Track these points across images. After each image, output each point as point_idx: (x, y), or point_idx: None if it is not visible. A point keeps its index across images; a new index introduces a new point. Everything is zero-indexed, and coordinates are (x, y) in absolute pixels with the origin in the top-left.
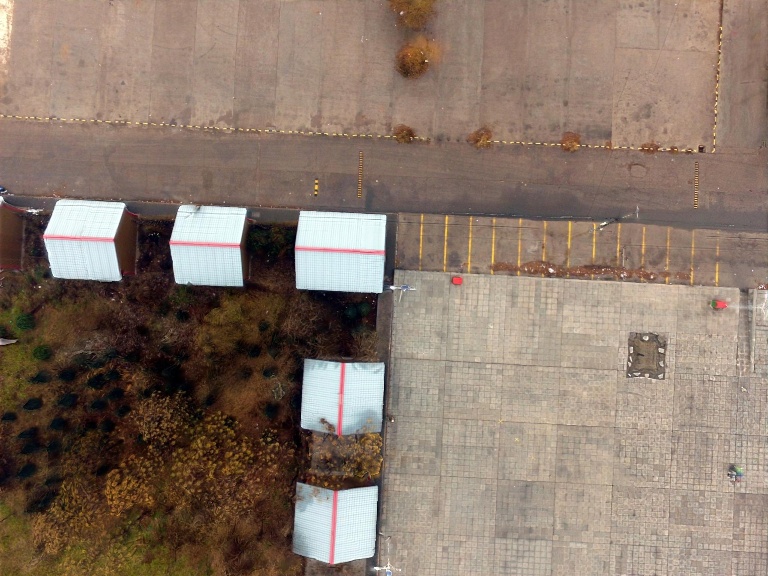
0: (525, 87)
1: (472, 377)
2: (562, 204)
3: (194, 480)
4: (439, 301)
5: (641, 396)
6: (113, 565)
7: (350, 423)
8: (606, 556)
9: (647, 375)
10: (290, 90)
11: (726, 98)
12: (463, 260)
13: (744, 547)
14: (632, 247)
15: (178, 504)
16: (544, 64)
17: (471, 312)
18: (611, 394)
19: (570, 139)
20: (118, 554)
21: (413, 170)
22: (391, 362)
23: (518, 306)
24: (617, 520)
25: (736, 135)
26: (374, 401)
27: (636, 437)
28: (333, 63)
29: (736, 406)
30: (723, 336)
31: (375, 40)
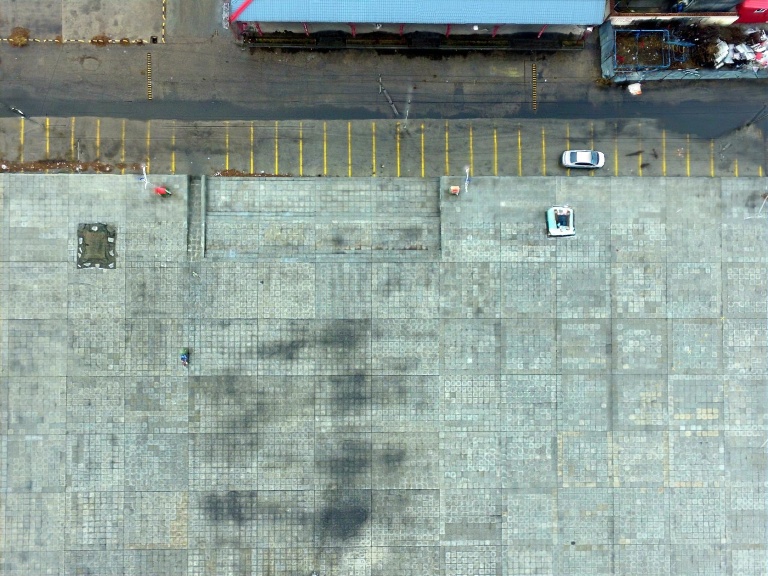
0: None
1: None
2: (14, 100)
3: None
4: None
5: (93, 286)
6: None
7: None
8: (62, 447)
9: (97, 265)
10: None
11: None
12: None
13: (200, 429)
14: (87, 140)
15: None
16: None
17: None
18: (62, 286)
19: (19, 34)
20: None
21: None
22: None
23: None
24: (72, 410)
25: (187, 25)
26: None
27: (89, 327)
28: None
29: (188, 291)
30: (172, 223)
31: None
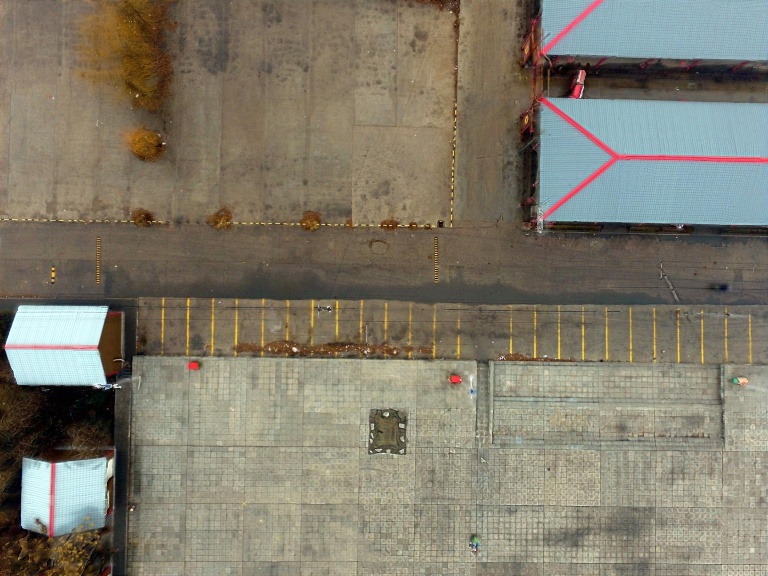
0: (264, 167)
1: (214, 461)
2: (305, 283)
3: None
4: (179, 386)
5: (383, 472)
6: None
7: (64, 523)
8: None
9: (388, 451)
10: (23, 177)
11: (463, 173)
12: (206, 343)
13: None
14: (375, 323)
15: None
16: (283, 144)
17: (212, 396)
18: (354, 471)
19: (310, 218)
20: None
21: (153, 254)
22: (132, 450)
23: (259, 388)
24: None
25: (474, 209)
26: (94, 497)
27: (379, 512)
28: (67, 148)
29: (476, 477)
30: (462, 409)
31: (110, 124)
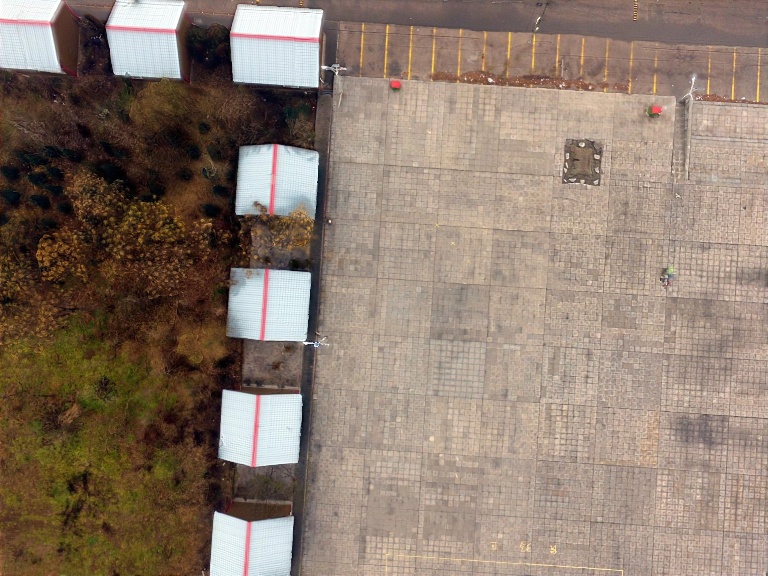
0: None
1: (410, 182)
2: (502, 15)
3: (124, 245)
4: (378, 106)
5: (576, 202)
6: (43, 326)
7: (282, 205)
8: (539, 358)
9: (582, 181)
10: None
11: None
12: (403, 69)
13: (675, 350)
14: (571, 58)
15: (110, 276)
16: None
17: (409, 117)
18: (547, 199)
19: None
20: (49, 316)
21: None
22: (330, 166)
23: (456, 112)
24: (550, 323)
25: None
26: (307, 188)
27: (571, 242)
28: None
29: (670, 212)
30: (658, 143)
31: None
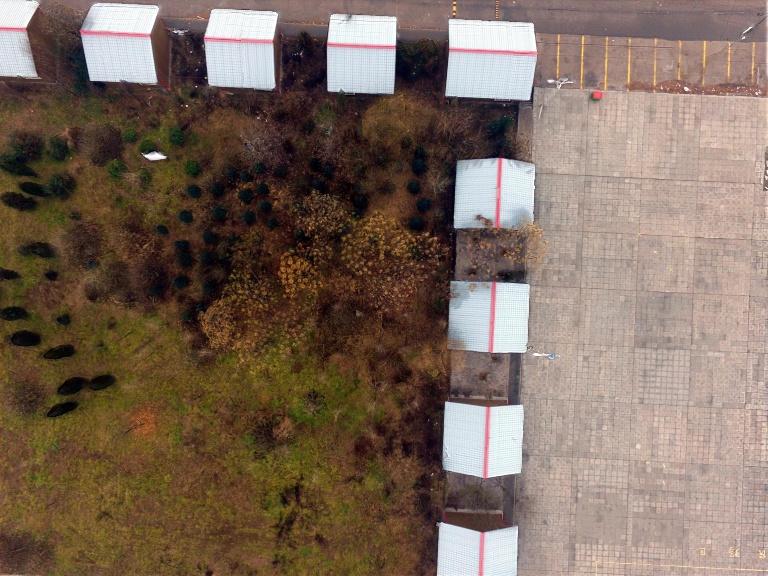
0: None
1: (611, 192)
2: (697, 24)
3: (365, 261)
4: (578, 117)
5: None
6: (288, 343)
7: (506, 218)
8: (743, 364)
9: None
10: None
11: None
12: (599, 79)
13: None
14: (767, 65)
15: (344, 292)
16: None
17: (610, 128)
18: (748, 207)
19: None
20: (292, 333)
21: None
22: None
23: (656, 122)
24: (754, 329)
25: None
26: (527, 200)
27: None
28: None
29: None
30: None
31: None
